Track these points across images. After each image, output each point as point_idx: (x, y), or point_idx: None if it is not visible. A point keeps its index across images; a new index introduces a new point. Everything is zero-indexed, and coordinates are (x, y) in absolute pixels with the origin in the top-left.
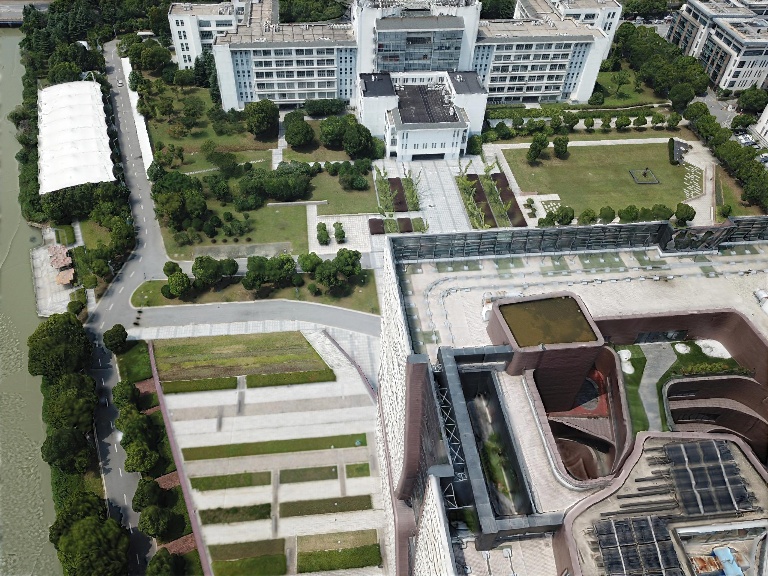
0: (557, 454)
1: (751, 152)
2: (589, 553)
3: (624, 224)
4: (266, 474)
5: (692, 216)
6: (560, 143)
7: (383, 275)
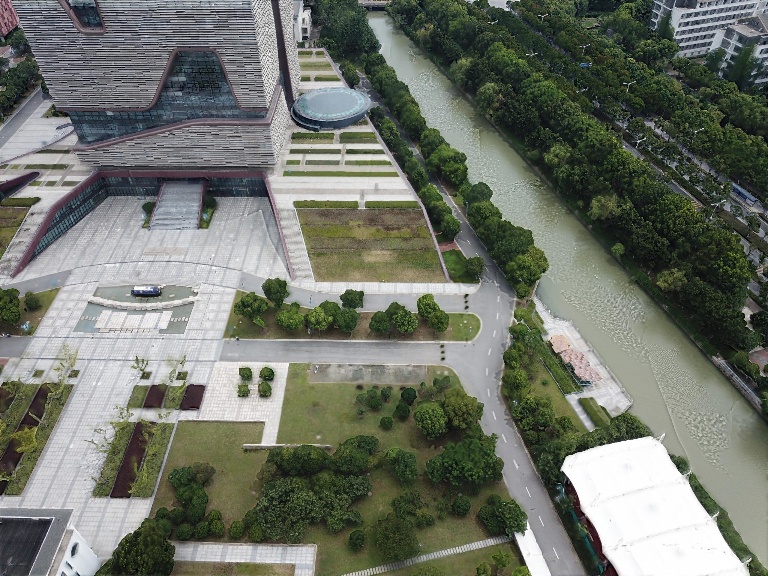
0: None
1: None
2: None
3: None
4: (347, 164)
5: None
6: None
7: None
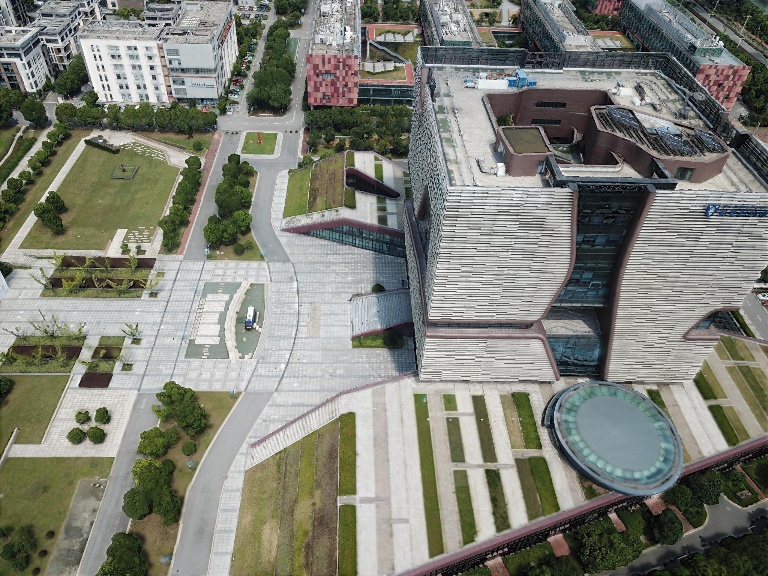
0: (606, 165)
1: (149, 106)
2: (673, 157)
3: None
4: (456, 474)
5: None
6: (55, 200)
7: (447, 222)
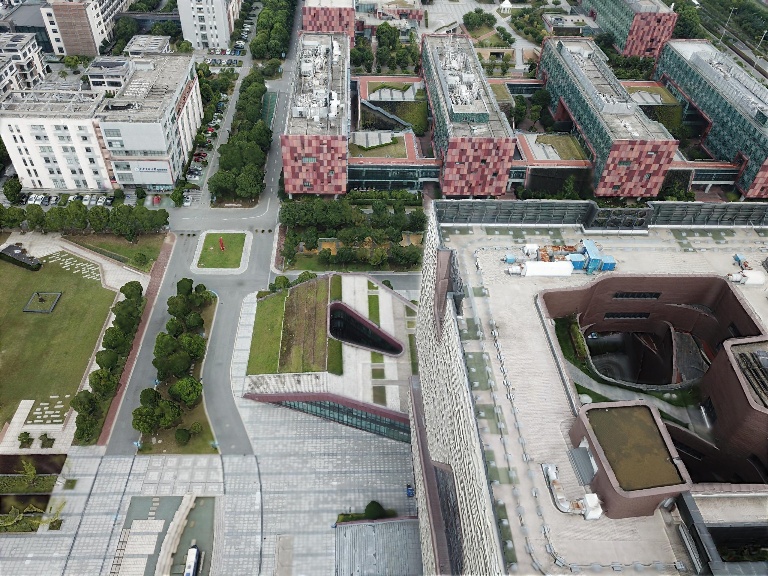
0: None
1: (80, 205)
2: None
3: (458, 329)
4: None
5: (140, 287)
6: None
7: None
